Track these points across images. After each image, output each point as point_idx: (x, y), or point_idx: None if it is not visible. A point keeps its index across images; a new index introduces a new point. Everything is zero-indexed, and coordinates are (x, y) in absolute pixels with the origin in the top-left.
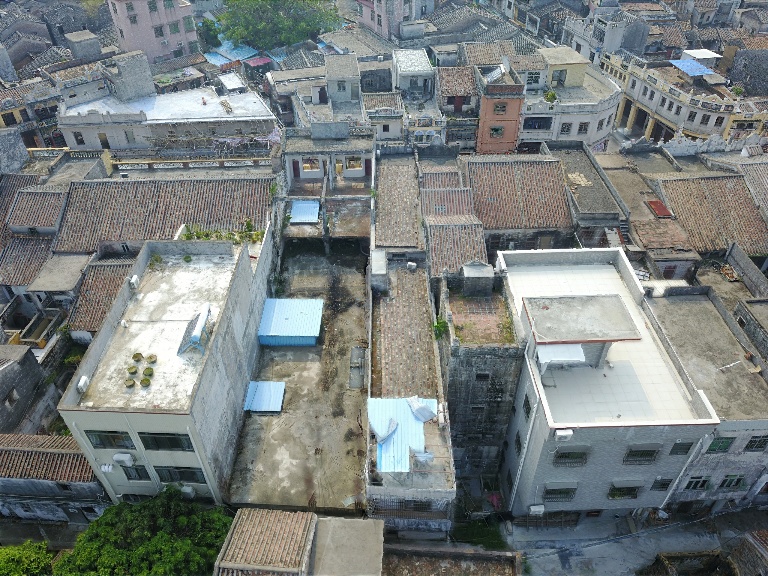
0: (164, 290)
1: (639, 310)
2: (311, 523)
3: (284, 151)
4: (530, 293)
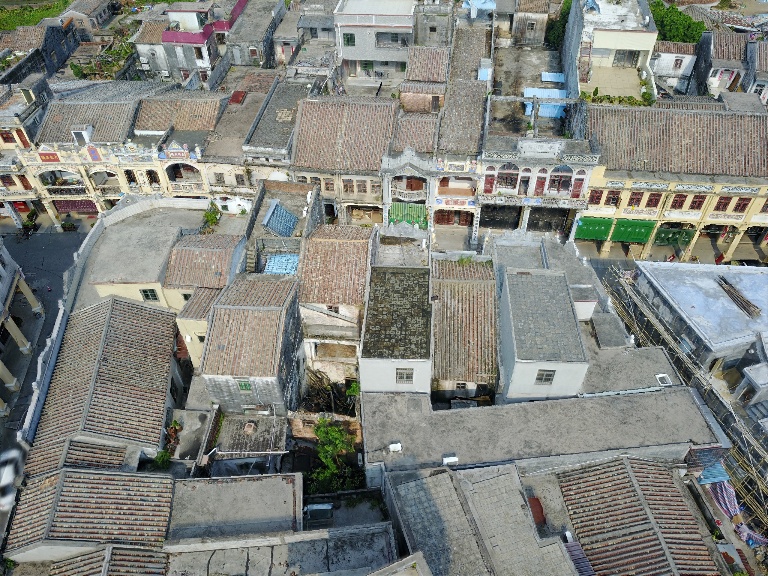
0: (627, 27)
1: (346, 4)
2: (518, 5)
3: (590, 140)
4: (400, 12)
